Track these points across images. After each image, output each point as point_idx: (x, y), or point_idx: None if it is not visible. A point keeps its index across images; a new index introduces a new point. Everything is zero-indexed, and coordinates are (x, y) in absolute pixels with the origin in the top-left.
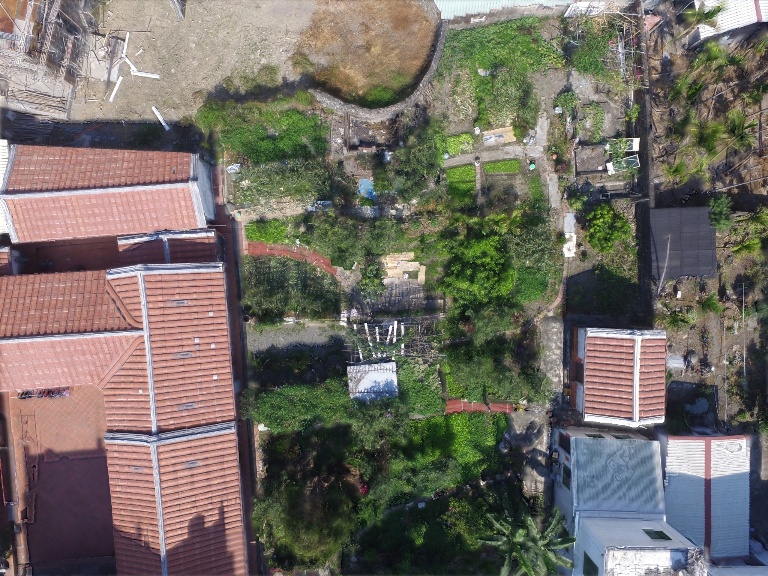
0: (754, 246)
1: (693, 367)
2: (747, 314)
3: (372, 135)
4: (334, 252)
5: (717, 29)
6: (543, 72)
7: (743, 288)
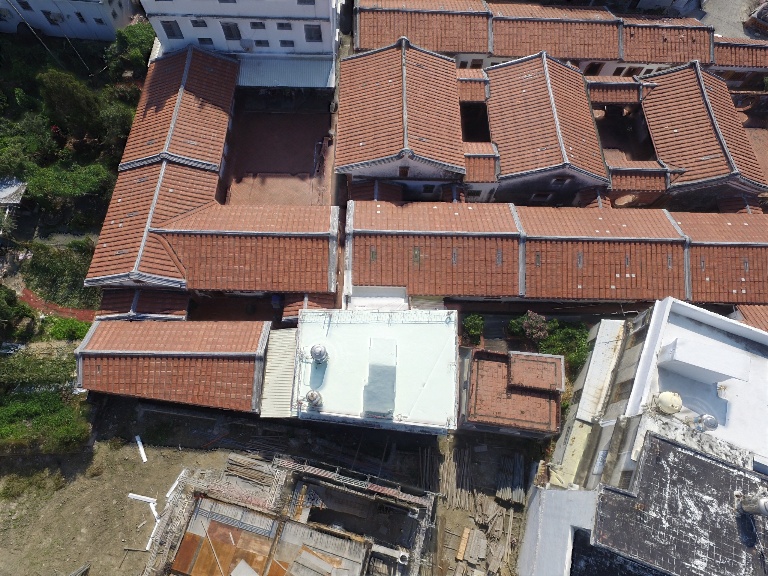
0: None
1: None
2: None
3: None
4: None
5: None
6: None
7: None
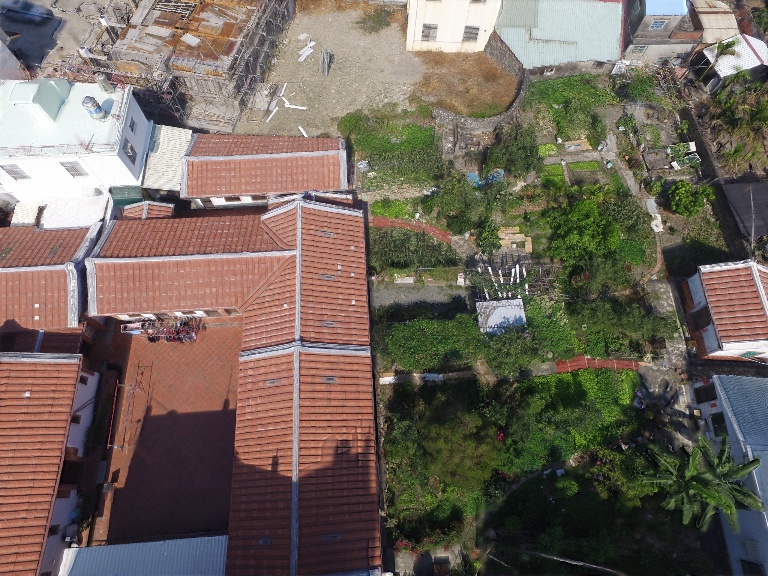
0: None
1: None
2: None
3: (476, 141)
4: (460, 204)
5: (732, 71)
6: (603, 107)
7: None
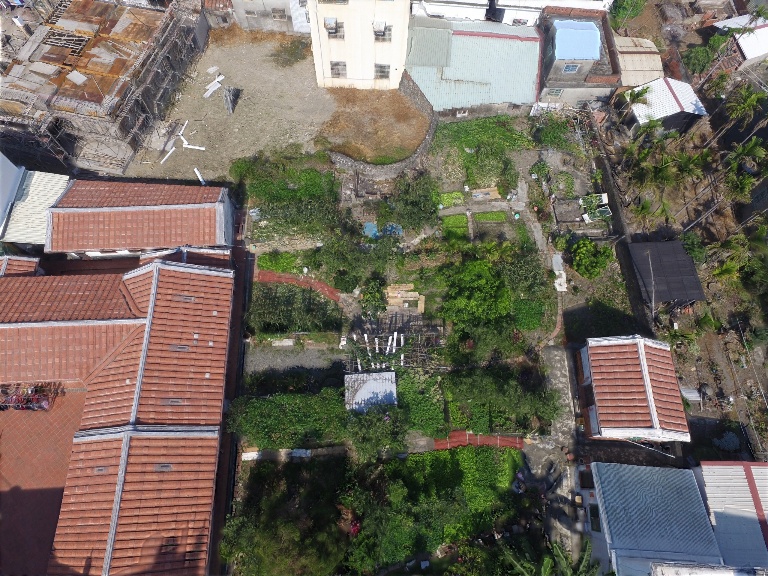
0: (736, 283)
1: (710, 400)
2: (750, 348)
3: (377, 188)
4: (339, 264)
5: (651, 117)
6: (518, 151)
7: (738, 322)
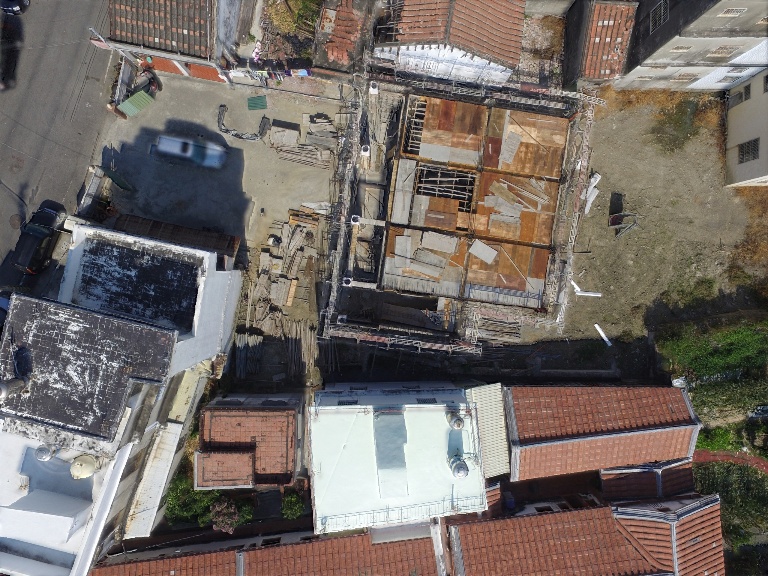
0: None
1: None
2: None
3: None
4: None
5: None
6: None
7: None
